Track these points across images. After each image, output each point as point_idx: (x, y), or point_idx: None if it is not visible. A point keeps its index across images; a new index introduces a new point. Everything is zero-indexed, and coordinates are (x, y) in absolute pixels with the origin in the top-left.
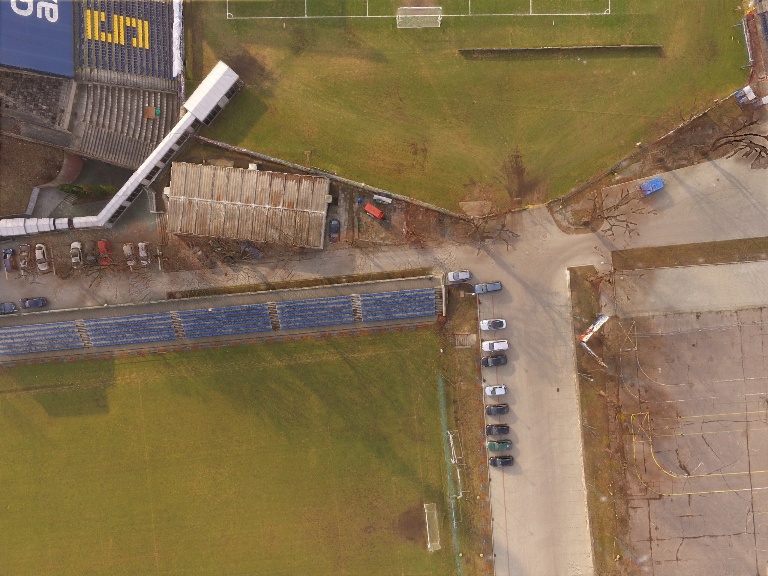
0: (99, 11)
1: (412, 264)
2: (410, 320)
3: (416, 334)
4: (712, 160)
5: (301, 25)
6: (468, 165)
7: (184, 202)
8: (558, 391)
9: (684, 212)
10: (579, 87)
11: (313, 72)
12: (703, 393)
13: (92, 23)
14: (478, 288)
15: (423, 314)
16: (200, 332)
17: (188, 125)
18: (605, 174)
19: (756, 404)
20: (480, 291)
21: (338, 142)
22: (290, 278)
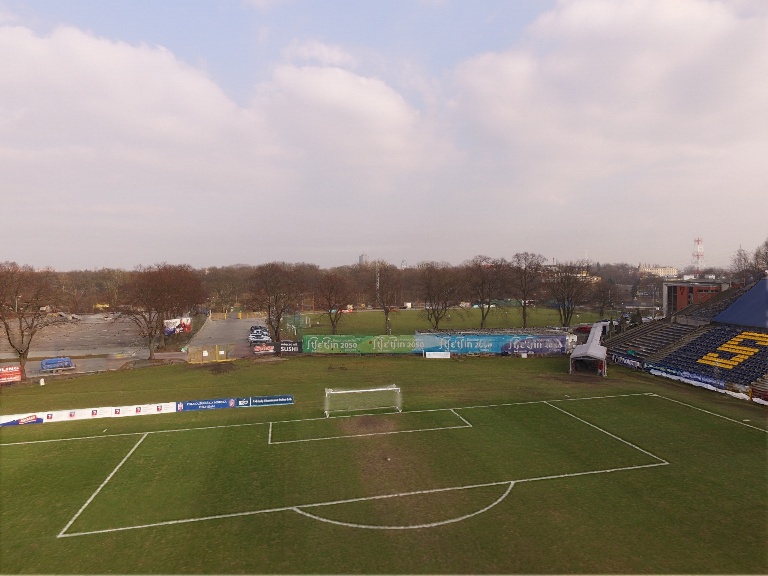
0: None
1: None
2: None
3: None
4: None
5: None
6: None
7: None
8: None
9: None
10: (99, 401)
11: None
12: None
13: None
14: None
15: None
16: None
17: None
18: None
19: None
20: None
21: (432, 365)
22: None
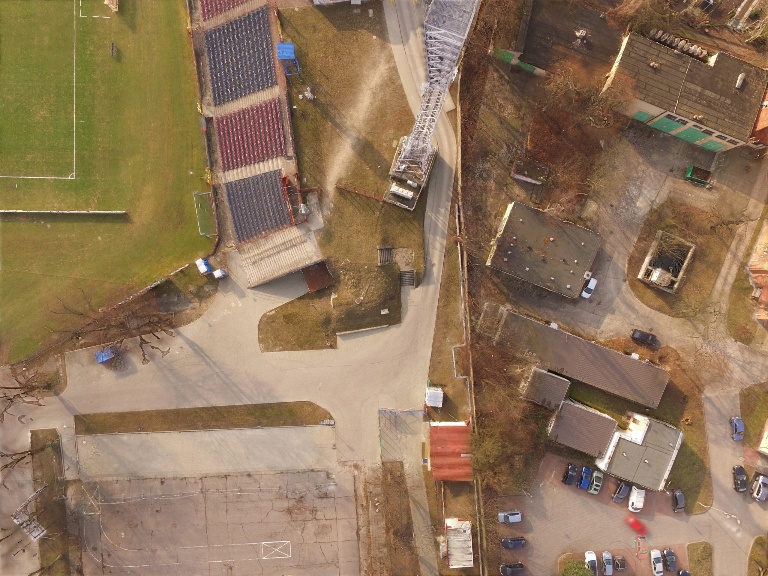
0: None
1: None
2: None
3: None
4: (176, 328)
5: None
6: None
7: None
8: (24, 552)
9: (147, 379)
10: (43, 250)
11: None
12: (166, 559)
13: None
14: None
15: None
16: None
17: None
18: (68, 338)
19: (219, 571)
20: None
21: None
22: None
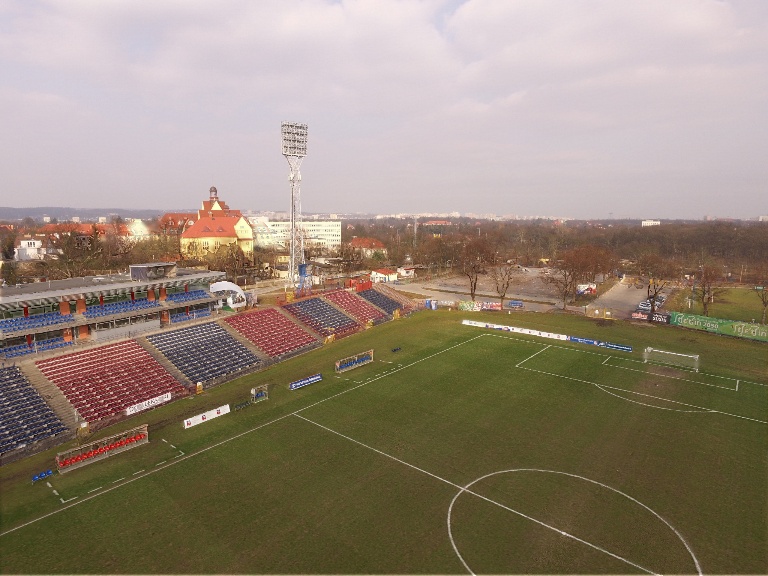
0: None
1: None
2: None
3: None
4: None
5: None
6: None
7: None
8: None
9: None
10: (533, 327)
11: None
12: None
13: None
14: None
15: None
16: None
17: None
18: None
19: None
20: None
21: None
22: None
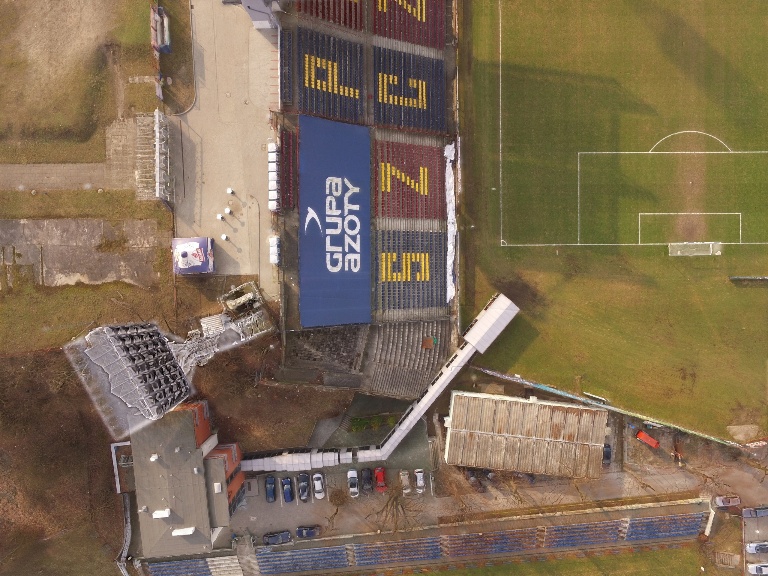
0: (391, 252)
1: (679, 487)
2: (671, 538)
3: (676, 551)
4: None
5: (574, 252)
6: (736, 390)
7: (465, 434)
8: None
9: None
10: None
11: (585, 298)
12: None
13: (385, 265)
14: (746, 512)
15: (686, 533)
16: (464, 551)
17: (469, 357)
18: None
19: None
20: (748, 515)
21: (608, 367)
22: (559, 502)
